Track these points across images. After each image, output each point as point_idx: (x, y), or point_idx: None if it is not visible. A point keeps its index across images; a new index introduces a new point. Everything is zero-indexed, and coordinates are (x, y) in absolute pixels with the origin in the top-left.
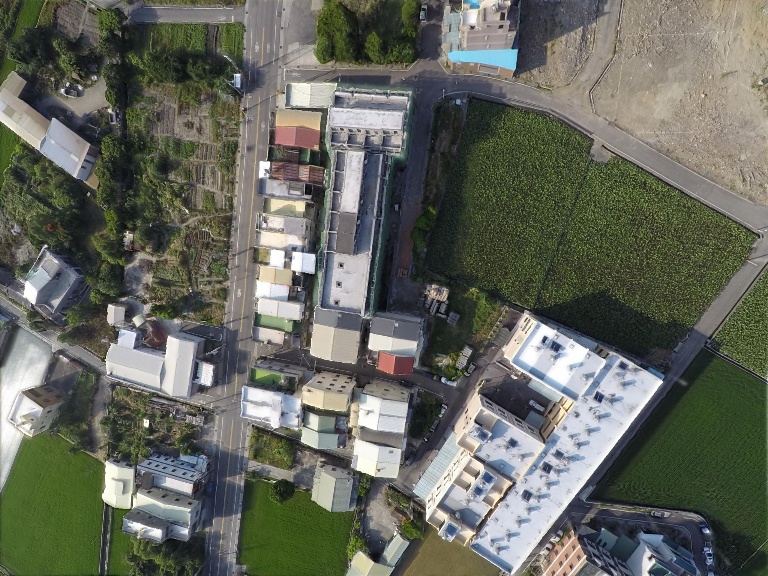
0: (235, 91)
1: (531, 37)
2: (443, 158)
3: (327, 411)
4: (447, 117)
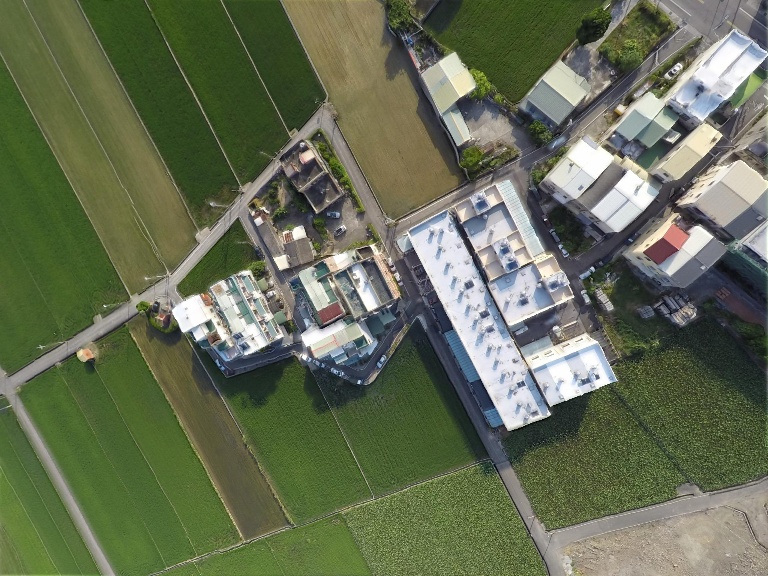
0: None
1: None
2: None
3: (659, 141)
4: None
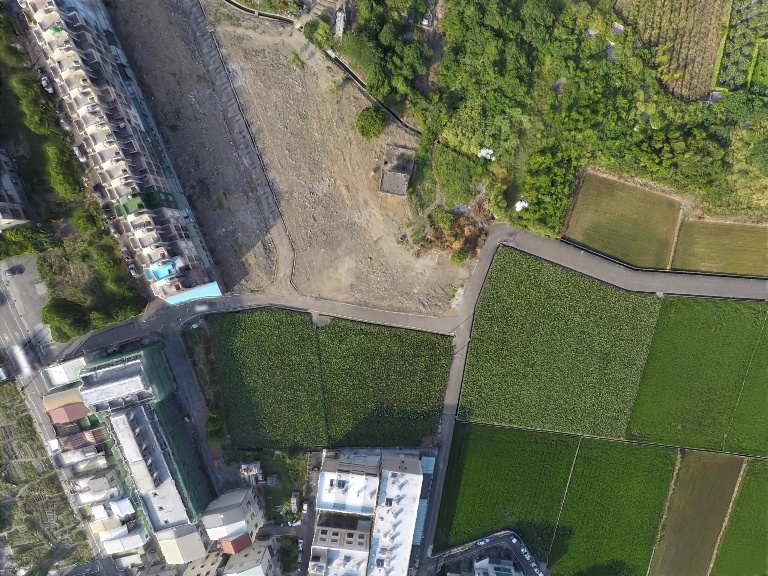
0: (4, 382)
1: (227, 260)
2: (206, 368)
3: None
4: (193, 337)
